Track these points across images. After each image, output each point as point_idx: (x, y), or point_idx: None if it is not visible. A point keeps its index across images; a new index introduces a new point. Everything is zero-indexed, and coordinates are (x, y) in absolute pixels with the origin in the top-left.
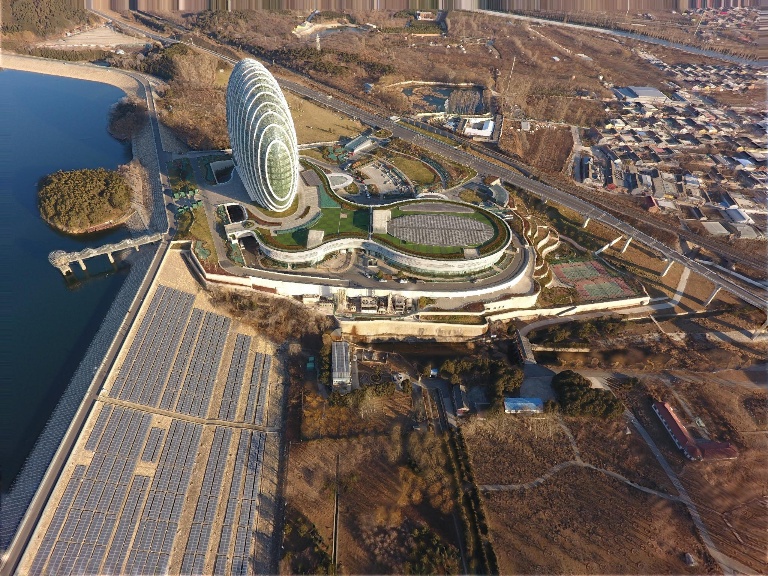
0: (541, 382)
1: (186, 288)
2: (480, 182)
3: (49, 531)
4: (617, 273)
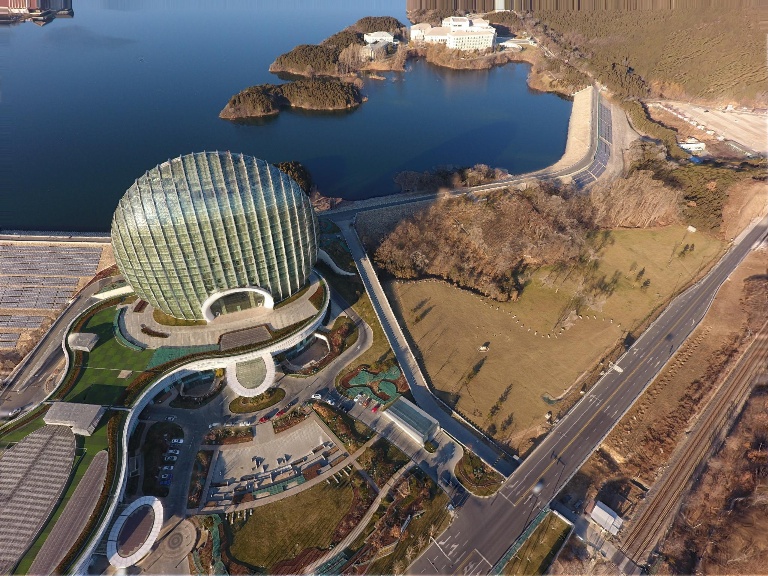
0: None
1: (103, 267)
2: None
3: None
4: None
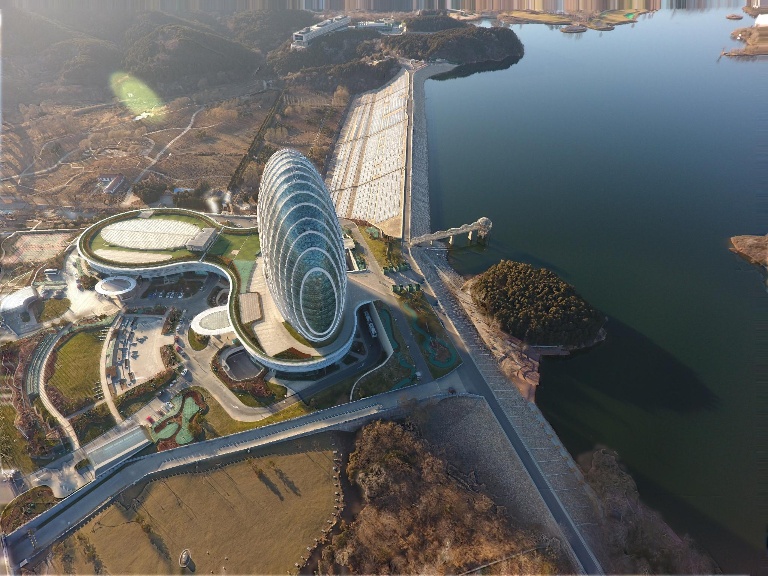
0: (163, 202)
1: None
2: (8, 334)
3: (402, 143)
4: (8, 251)
